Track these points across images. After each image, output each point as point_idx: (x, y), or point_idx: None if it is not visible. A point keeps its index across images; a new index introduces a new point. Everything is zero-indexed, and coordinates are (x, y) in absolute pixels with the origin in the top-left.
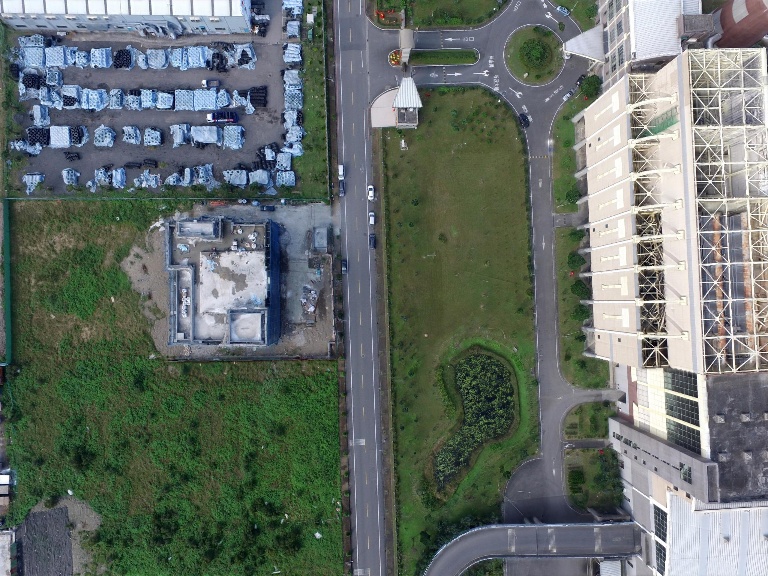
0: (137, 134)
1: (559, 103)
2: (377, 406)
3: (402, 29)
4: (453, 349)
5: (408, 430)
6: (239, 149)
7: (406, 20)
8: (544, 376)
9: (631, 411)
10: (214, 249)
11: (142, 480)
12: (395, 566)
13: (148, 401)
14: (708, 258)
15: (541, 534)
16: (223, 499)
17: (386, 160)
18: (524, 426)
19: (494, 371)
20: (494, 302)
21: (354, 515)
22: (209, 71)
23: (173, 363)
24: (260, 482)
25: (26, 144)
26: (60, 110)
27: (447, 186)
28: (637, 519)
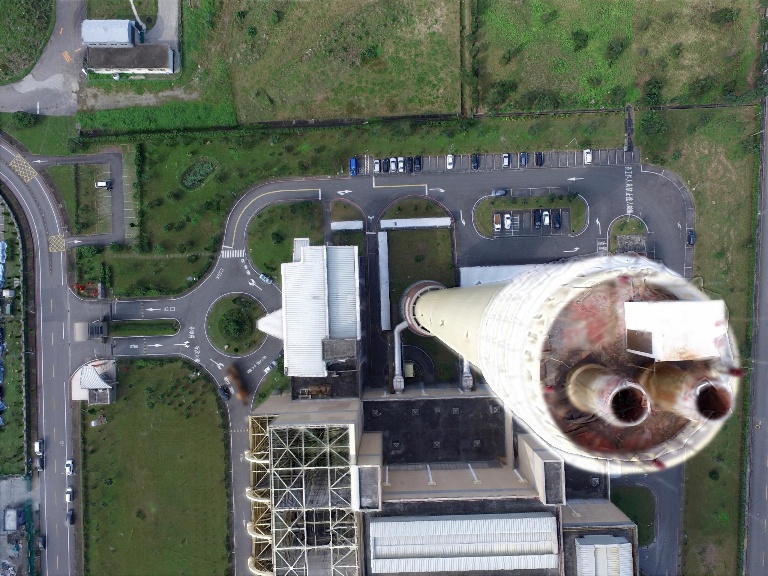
0: None
1: (262, 374)
2: None
3: (76, 322)
4: None
5: None
6: None
7: (106, 291)
8: None
9: None
10: None
11: None
12: None
13: None
14: None
15: None
16: None
17: (85, 434)
18: None
19: None
20: None
21: None
22: None
23: None
24: None
25: None
26: None
27: (146, 461)
28: None
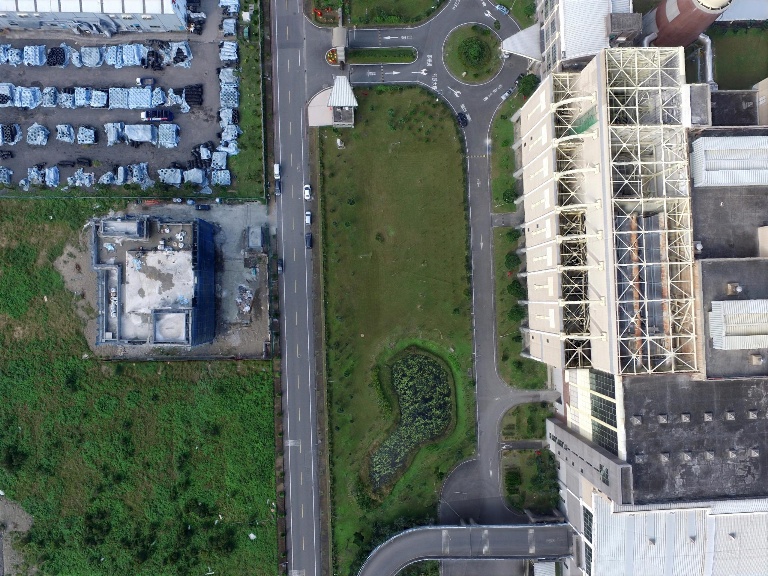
0: (71, 132)
1: (498, 102)
2: (313, 406)
3: (335, 27)
4: (389, 349)
5: (344, 431)
6: (174, 148)
7: (344, 18)
8: (481, 377)
9: (565, 412)
10: (141, 248)
11: (74, 480)
12: (330, 567)
13: (81, 401)
14: (624, 258)
15: (475, 535)
16: (156, 500)
17: (323, 159)
18: (461, 427)
19: (431, 371)
20: (431, 302)
21: (289, 516)
22: (144, 69)
23: (106, 363)
24: (194, 483)
25: None
26: None
27: (384, 185)
28: (570, 520)
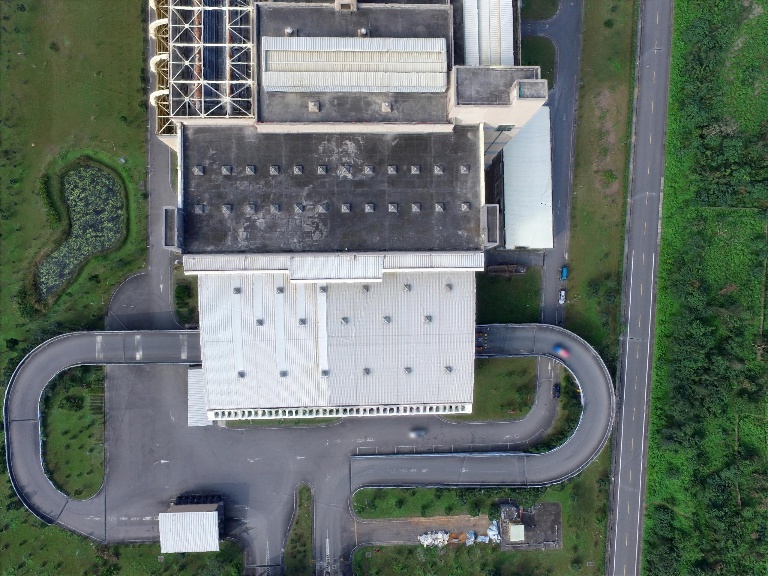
0: None
1: None
2: None
3: None
4: (60, 159)
5: (11, 240)
6: None
7: None
8: (155, 190)
9: None
10: None
11: None
12: None
13: None
14: (181, 1)
15: (128, 341)
16: None
17: None
18: (132, 240)
19: (104, 184)
20: (106, 114)
21: None
22: None
23: None
24: None
25: None
26: None
27: None
28: None
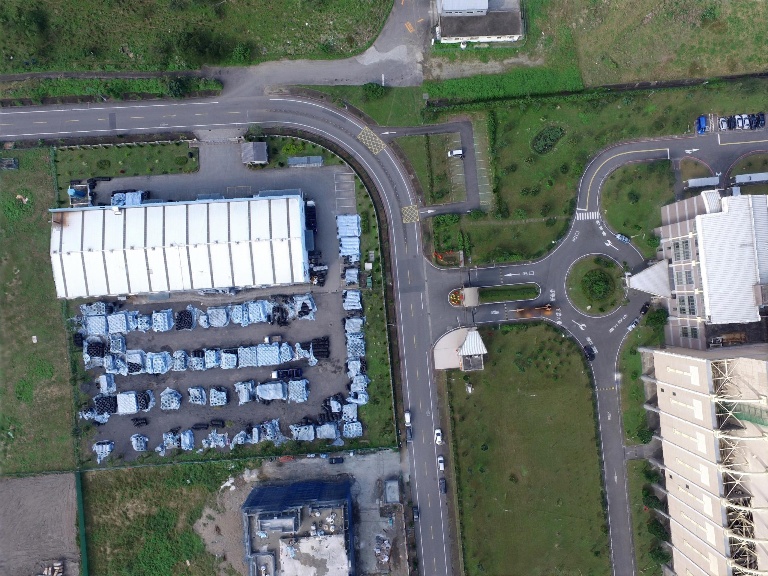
0: (202, 395)
1: (624, 333)
2: None
3: (466, 288)
4: None
5: None
6: (304, 402)
7: (464, 258)
8: None
9: None
10: (293, 534)
11: None
12: None
13: None
14: None
15: None
16: None
17: (452, 402)
18: None
19: None
20: (569, 540)
21: None
22: (270, 325)
23: None
24: None
25: (94, 413)
26: (125, 376)
27: (515, 425)
28: None
